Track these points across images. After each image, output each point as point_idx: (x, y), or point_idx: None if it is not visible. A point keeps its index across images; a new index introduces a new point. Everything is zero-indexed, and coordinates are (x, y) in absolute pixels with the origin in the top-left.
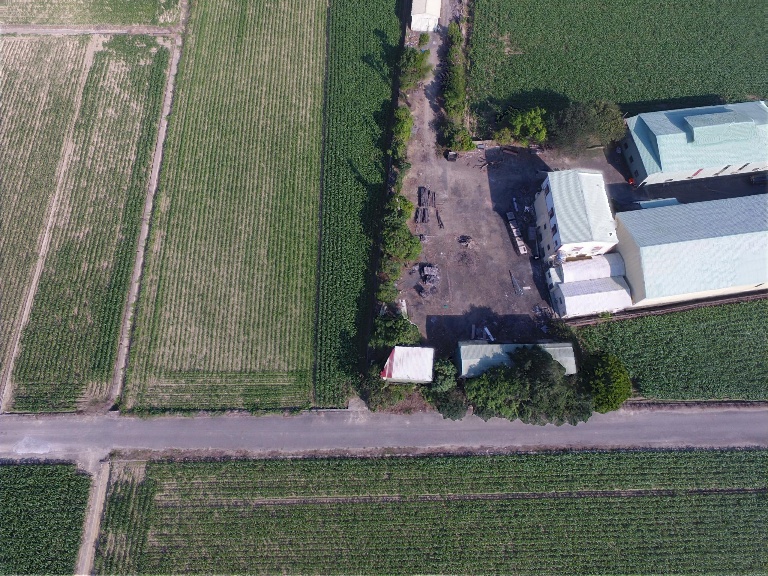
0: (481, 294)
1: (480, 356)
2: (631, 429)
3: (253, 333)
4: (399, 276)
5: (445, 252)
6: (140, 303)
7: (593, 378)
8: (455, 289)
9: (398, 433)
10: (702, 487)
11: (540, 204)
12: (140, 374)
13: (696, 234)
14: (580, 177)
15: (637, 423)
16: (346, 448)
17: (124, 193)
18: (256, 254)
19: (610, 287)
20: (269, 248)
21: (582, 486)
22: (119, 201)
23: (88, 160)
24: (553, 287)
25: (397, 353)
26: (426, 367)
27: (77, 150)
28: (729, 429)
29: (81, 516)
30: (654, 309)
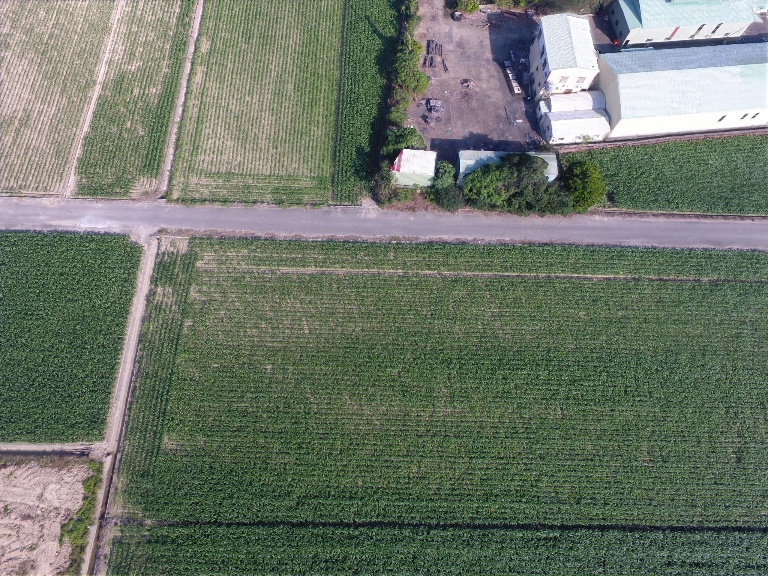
0: (479, 124)
1: (476, 158)
2: (604, 231)
3: (281, 147)
4: (408, 107)
5: (449, 91)
6: (184, 120)
7: (572, 177)
8: (457, 119)
9: (403, 226)
10: (663, 275)
11: (534, 52)
12: (184, 174)
13: (667, 67)
14: (568, 19)
15: (610, 226)
16: (359, 235)
17: (170, 37)
18: (284, 88)
19: (591, 115)
20: (295, 83)
21: (560, 270)
22: (165, 43)
23: (138, 11)
24: (542, 117)
25: (405, 154)
26: (429, 165)
27: (129, 3)
28: (690, 234)
29: (135, 273)
30: (630, 140)
